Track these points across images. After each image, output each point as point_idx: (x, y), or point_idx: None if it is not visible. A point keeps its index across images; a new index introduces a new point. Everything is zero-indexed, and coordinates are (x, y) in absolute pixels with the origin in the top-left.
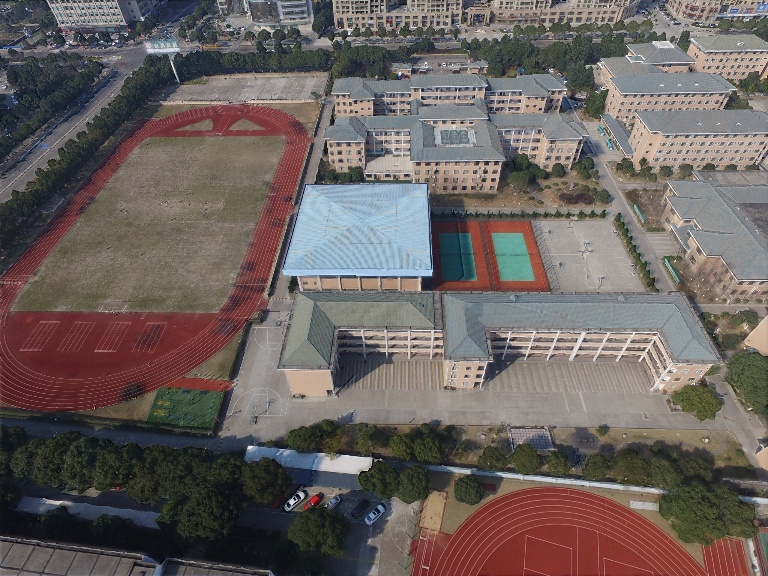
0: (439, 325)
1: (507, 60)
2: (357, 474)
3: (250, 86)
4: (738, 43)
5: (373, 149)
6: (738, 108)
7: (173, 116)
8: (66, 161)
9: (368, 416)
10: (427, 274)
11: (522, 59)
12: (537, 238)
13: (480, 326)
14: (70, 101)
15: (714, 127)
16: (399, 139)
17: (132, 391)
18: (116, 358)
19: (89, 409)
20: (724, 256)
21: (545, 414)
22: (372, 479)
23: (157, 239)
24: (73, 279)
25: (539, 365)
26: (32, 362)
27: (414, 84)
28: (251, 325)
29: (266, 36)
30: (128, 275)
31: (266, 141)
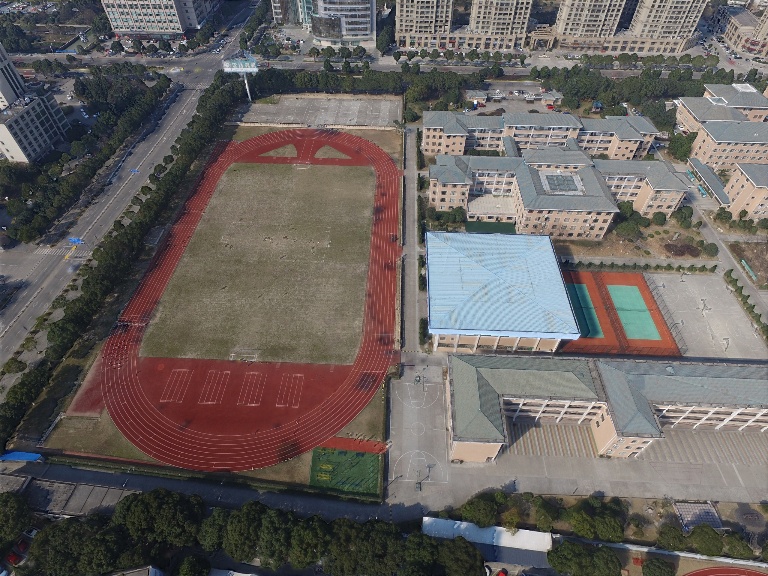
0: (602, 396)
1: (582, 93)
2: (539, 551)
3: (324, 108)
4: None
5: (473, 189)
6: None
7: (253, 139)
8: (163, 190)
9: (531, 485)
10: (573, 338)
11: (597, 92)
12: (653, 292)
13: (644, 399)
14: (144, 118)
15: None
16: (501, 180)
17: (287, 451)
18: (261, 413)
19: (248, 470)
20: None
21: (704, 487)
22: (568, 562)
23: (271, 279)
24: (195, 322)
25: (686, 433)
26: (176, 415)
27: (509, 122)
28: (390, 380)
29: (332, 53)
30: (251, 319)
31: (356, 172)
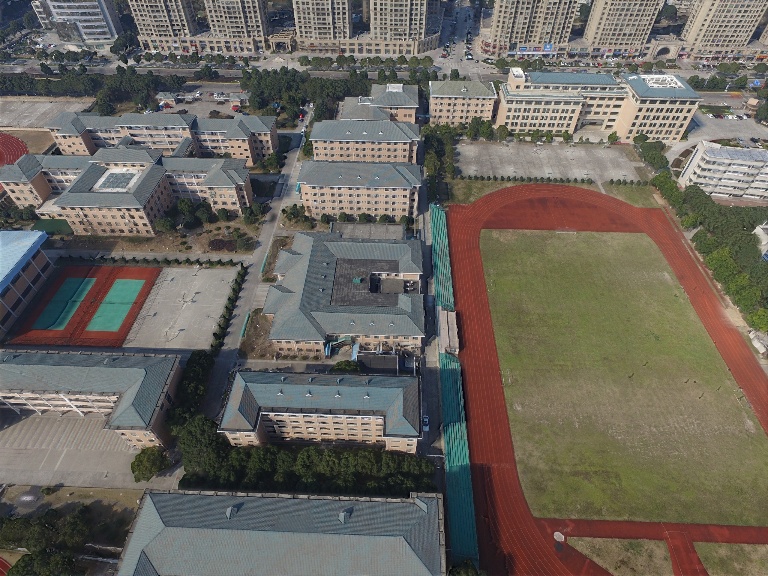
0: None
1: (268, 94)
2: None
3: (11, 110)
4: (462, 89)
5: (58, 187)
6: (432, 156)
7: None
8: None
9: None
10: None
11: (281, 93)
12: (154, 286)
13: None
14: None
15: (354, 180)
16: None
17: None
18: None
19: None
20: (275, 314)
21: (15, 471)
22: None
23: None
24: None
25: (50, 420)
26: None
27: (118, 122)
28: None
29: (57, 57)
30: None
31: None
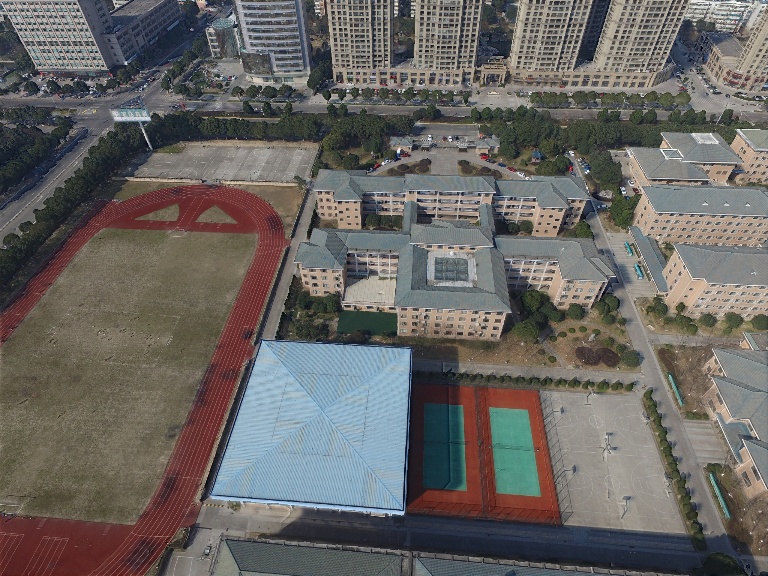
0: None
1: (522, 140)
2: None
3: (229, 159)
4: None
5: (355, 269)
6: None
7: (137, 198)
8: None
9: None
10: (397, 513)
11: (539, 140)
12: (546, 421)
13: None
14: (26, 172)
15: None
16: (386, 261)
17: None
18: None
19: None
20: None
21: None
22: None
23: (83, 391)
24: None
25: None
26: None
27: (409, 186)
28: (172, 551)
29: (255, 93)
30: (37, 450)
31: (235, 241)
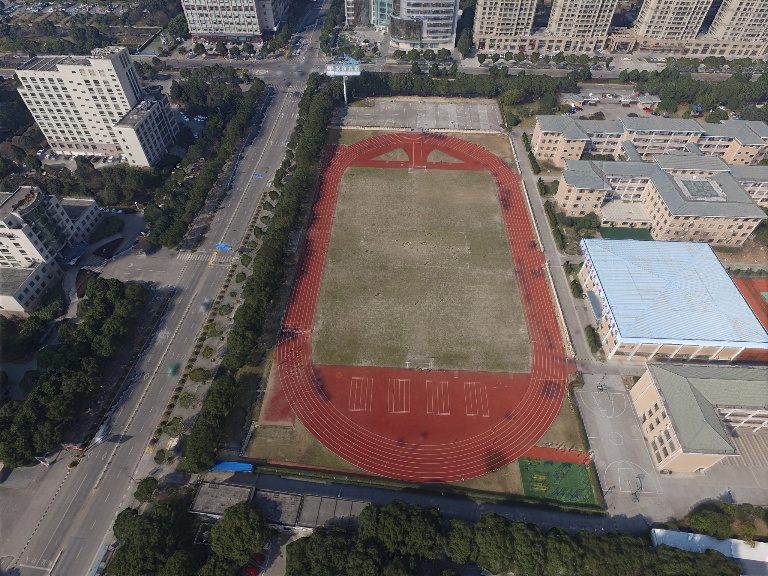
0: None
1: (680, 96)
2: None
3: (422, 111)
4: None
5: None
6: None
7: (361, 143)
8: (295, 195)
9: (747, 496)
10: (765, 347)
11: (695, 96)
12: None
13: None
14: None
15: None
16: (633, 186)
17: (492, 461)
18: (454, 422)
19: (458, 480)
20: None
21: None
22: None
23: (422, 286)
24: (359, 329)
25: None
26: (369, 424)
27: (632, 127)
28: (573, 389)
29: (417, 56)
30: (415, 327)
31: (473, 176)
